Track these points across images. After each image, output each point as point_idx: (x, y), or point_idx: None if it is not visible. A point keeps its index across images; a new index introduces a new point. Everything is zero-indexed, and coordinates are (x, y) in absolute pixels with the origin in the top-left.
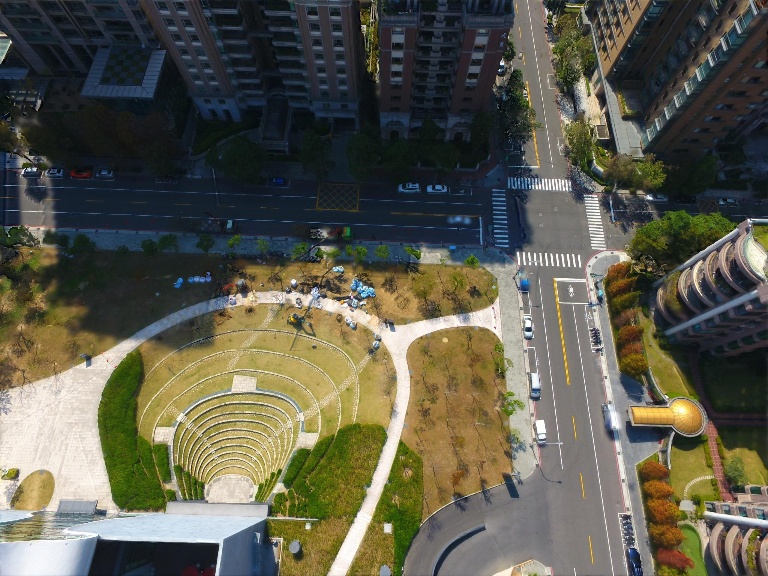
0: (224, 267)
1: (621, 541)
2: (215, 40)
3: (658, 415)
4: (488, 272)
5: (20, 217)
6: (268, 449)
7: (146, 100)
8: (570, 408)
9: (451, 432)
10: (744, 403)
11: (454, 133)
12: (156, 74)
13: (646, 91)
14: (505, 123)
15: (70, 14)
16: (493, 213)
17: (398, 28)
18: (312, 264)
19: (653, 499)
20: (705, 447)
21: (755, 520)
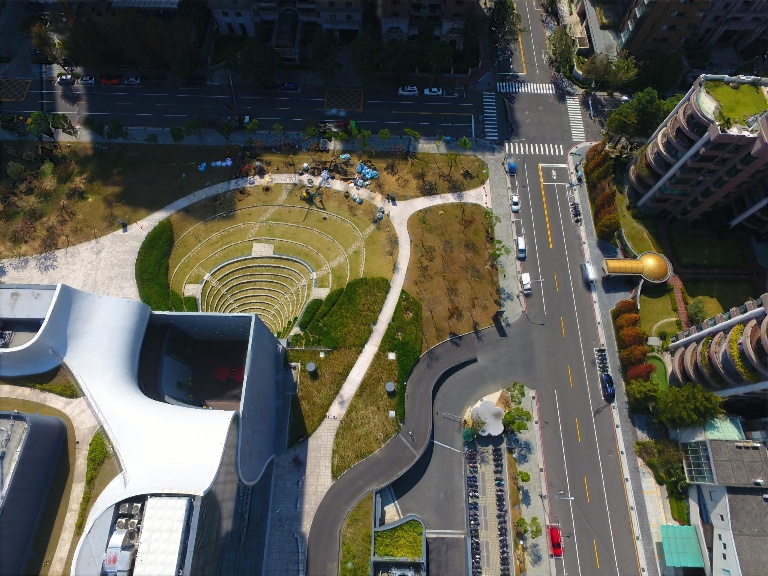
0: (243, 155)
1: (596, 369)
2: None
3: (629, 265)
4: (479, 159)
5: None
6: (285, 304)
7: (170, 11)
8: (552, 266)
9: (447, 284)
10: (706, 261)
11: (448, 41)
12: None
13: (621, 2)
14: (495, 37)
15: None
16: (484, 112)
17: None
18: (321, 153)
19: (623, 328)
20: (671, 295)
21: (708, 329)
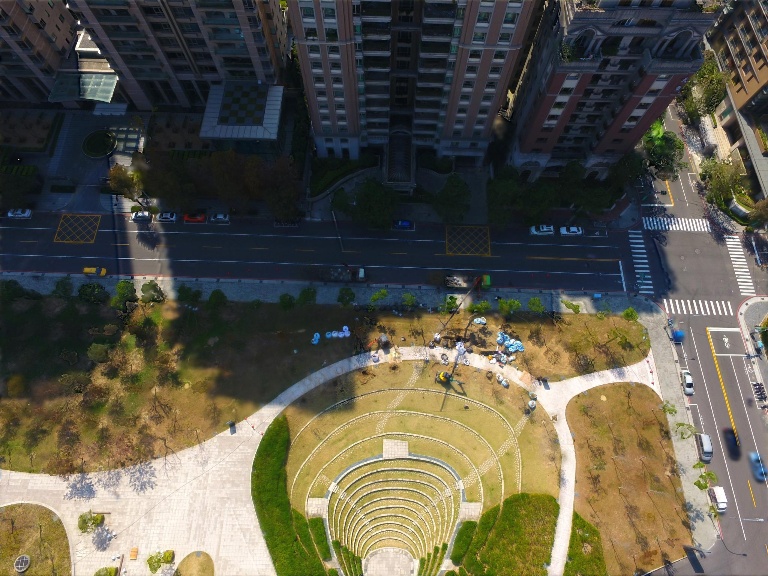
0: (360, 320)
1: None
2: (358, 82)
3: None
4: (636, 322)
5: (135, 266)
6: (426, 520)
7: (268, 141)
8: (744, 472)
9: (624, 501)
10: None
11: (589, 172)
12: (276, 113)
13: None
14: None
15: (187, 50)
16: (633, 256)
17: (574, 73)
18: (451, 315)
19: None
20: None
21: None
